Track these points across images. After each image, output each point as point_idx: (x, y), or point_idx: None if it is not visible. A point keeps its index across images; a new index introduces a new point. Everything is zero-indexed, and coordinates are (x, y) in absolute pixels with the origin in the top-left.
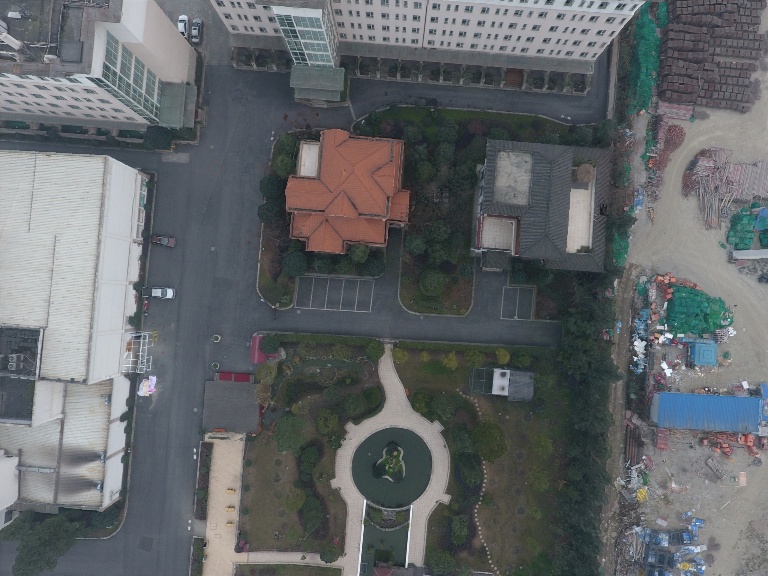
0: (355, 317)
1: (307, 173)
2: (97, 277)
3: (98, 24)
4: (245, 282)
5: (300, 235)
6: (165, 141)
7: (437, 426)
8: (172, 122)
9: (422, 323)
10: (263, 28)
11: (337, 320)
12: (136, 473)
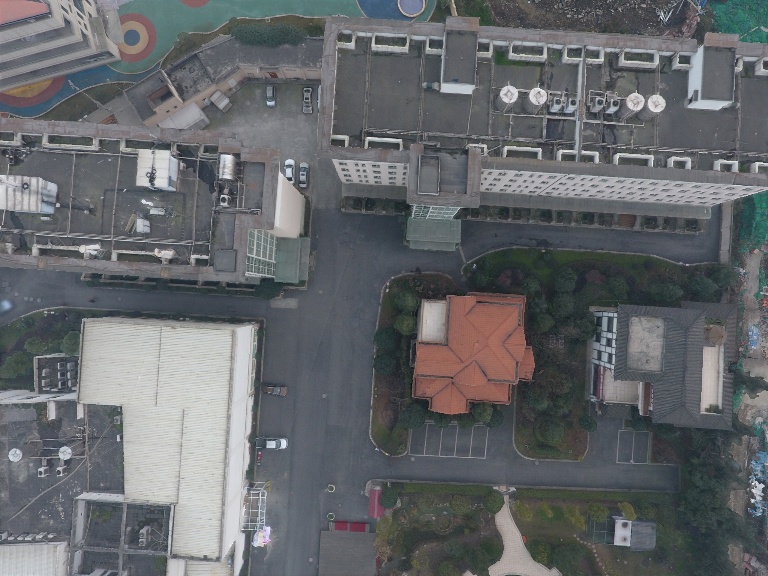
0: (470, 464)
1: (429, 332)
2: (228, 452)
3: (250, 230)
4: (358, 429)
5: (423, 395)
6: (278, 292)
7: (555, 573)
8: (288, 277)
9: (537, 468)
10: (379, 181)
11: (452, 467)
12: None
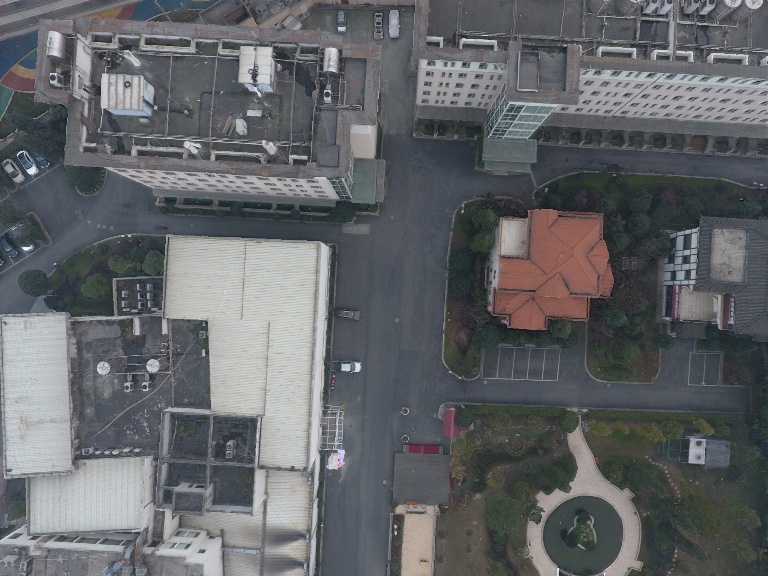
0: (542, 386)
1: (507, 249)
2: (314, 364)
3: (352, 126)
4: (430, 353)
5: (502, 312)
6: (352, 215)
7: (627, 493)
8: (364, 198)
9: (609, 391)
10: (455, 101)
11: (524, 390)
12: (328, 546)
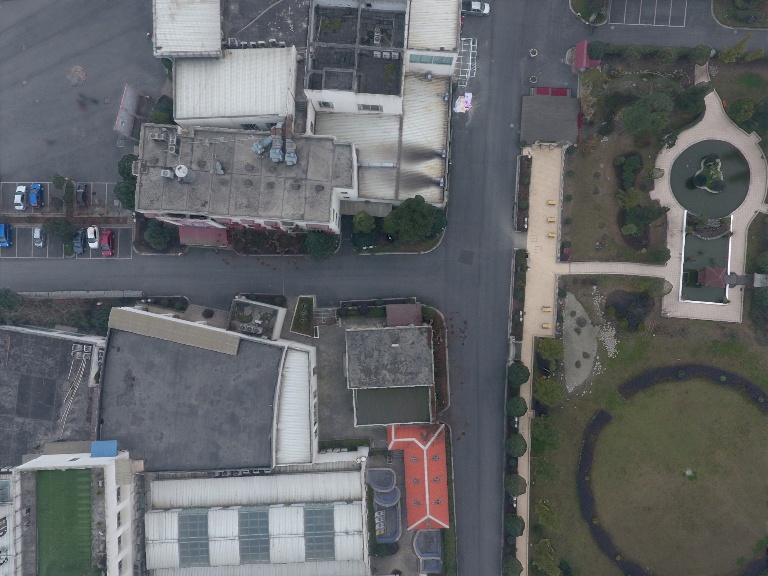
0: (669, 32)
1: None
2: None
3: None
4: None
5: None
6: None
7: (754, 138)
8: None
9: (736, 37)
10: None
11: (651, 35)
12: (454, 188)
